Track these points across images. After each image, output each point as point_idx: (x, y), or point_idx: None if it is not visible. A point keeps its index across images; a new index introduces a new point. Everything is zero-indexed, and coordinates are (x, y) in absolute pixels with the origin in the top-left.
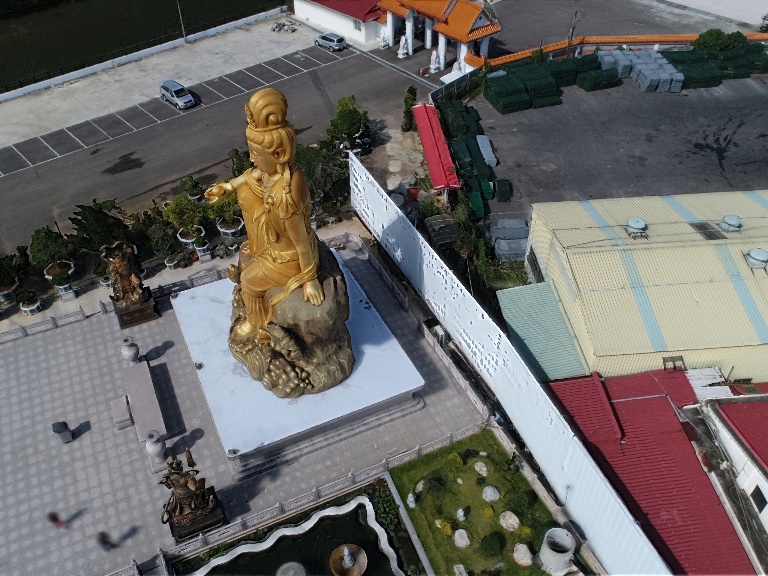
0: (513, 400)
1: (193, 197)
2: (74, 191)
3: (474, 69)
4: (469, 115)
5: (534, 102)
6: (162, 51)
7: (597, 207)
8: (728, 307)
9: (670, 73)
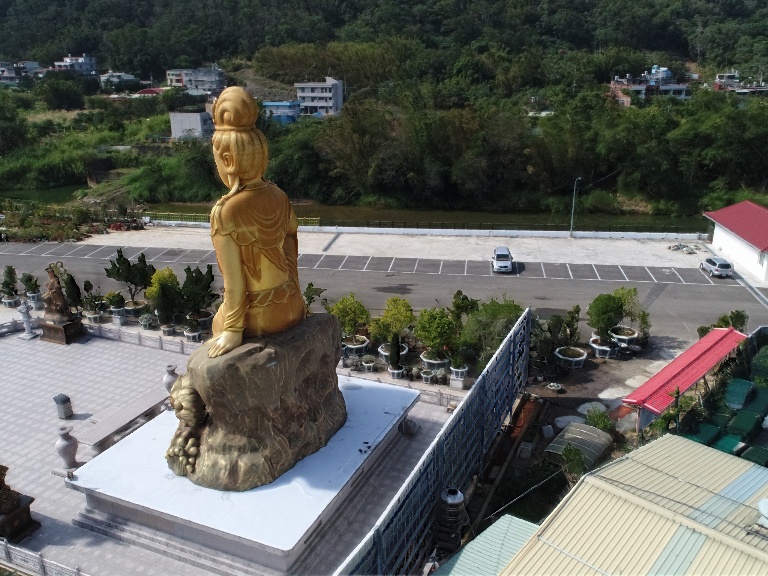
0: None
1: None
2: (337, 291)
3: None
4: None
5: None
6: (542, 237)
7: None
8: None
9: None
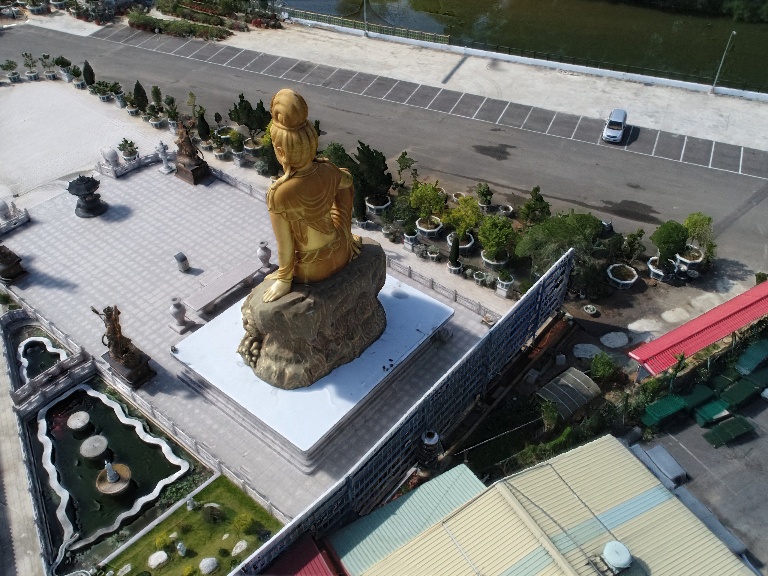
0: None
1: (480, 203)
2: (438, 145)
3: None
4: None
5: None
6: (680, 88)
7: (660, 509)
8: None
9: None
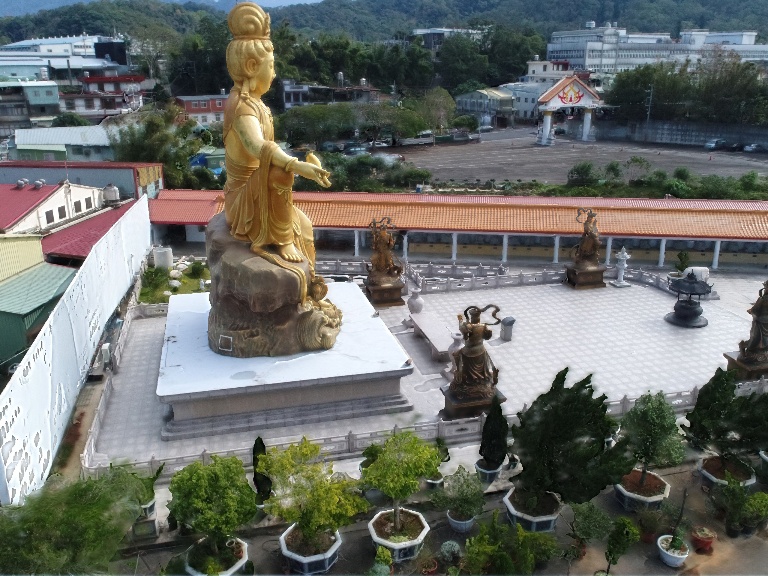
0: None
1: None
2: None
3: None
4: None
5: None
6: None
7: None
8: None
9: None
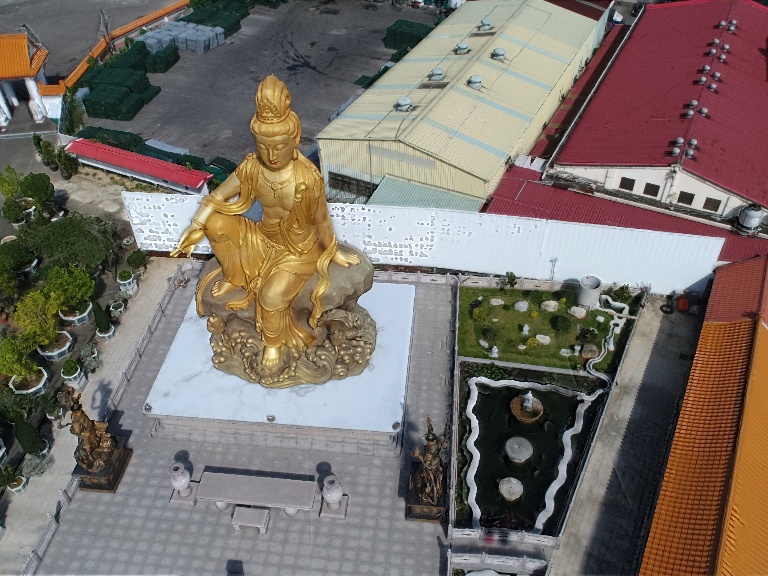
0: (464, 252)
1: None
2: None
3: (62, 97)
4: (116, 132)
5: (143, 98)
6: None
7: (355, 113)
8: (498, 115)
9: (210, 30)
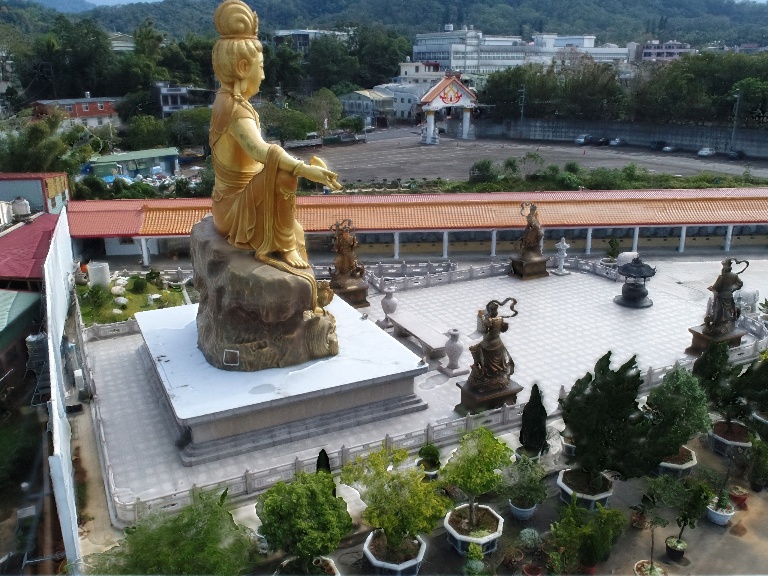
0: None
1: None
2: None
3: None
4: None
5: None
6: None
7: None
8: None
9: None
